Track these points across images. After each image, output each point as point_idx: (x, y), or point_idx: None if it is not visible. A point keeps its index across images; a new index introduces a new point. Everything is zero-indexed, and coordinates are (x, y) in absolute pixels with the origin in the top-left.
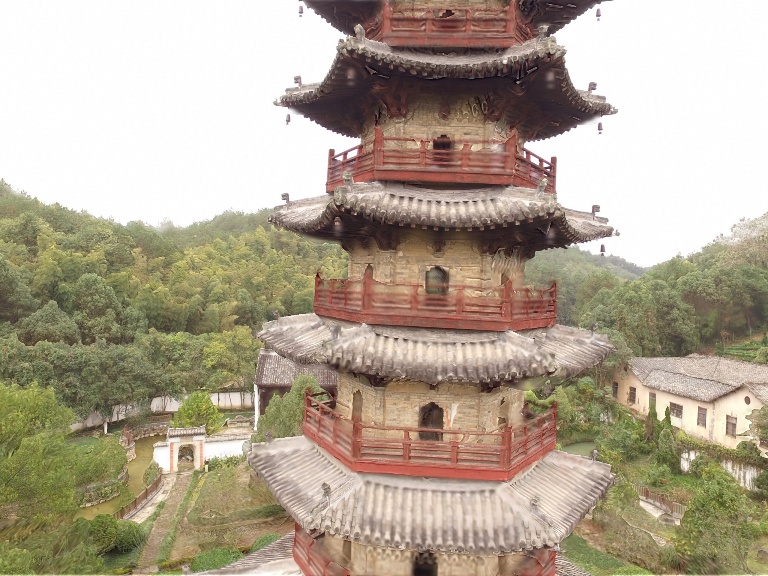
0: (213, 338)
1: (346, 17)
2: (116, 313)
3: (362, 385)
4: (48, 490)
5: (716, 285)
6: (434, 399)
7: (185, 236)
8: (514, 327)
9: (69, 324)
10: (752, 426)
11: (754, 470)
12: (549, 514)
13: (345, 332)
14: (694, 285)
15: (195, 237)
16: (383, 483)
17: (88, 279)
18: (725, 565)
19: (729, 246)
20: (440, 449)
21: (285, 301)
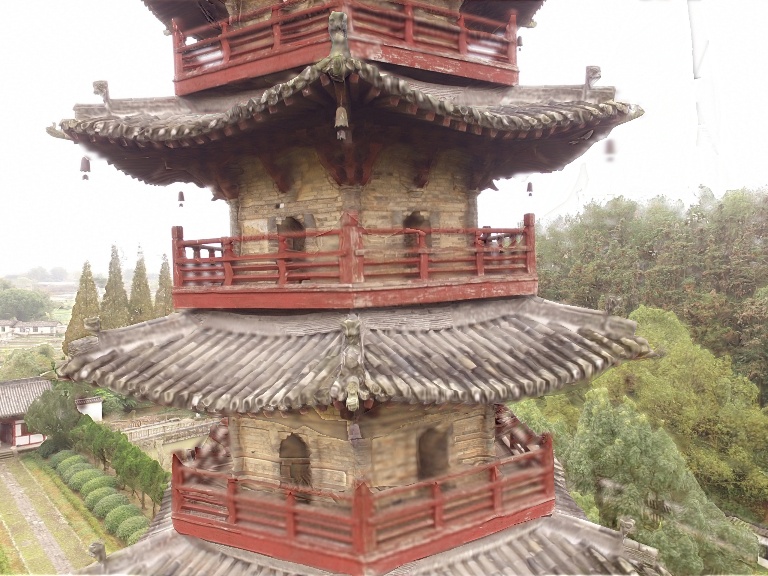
0: None
1: (489, 24)
2: None
3: None
4: None
5: None
6: None
7: None
8: None
9: None
10: None
11: None
12: None
13: None
14: None
15: None
16: None
17: None
18: None
19: None
20: None
21: None
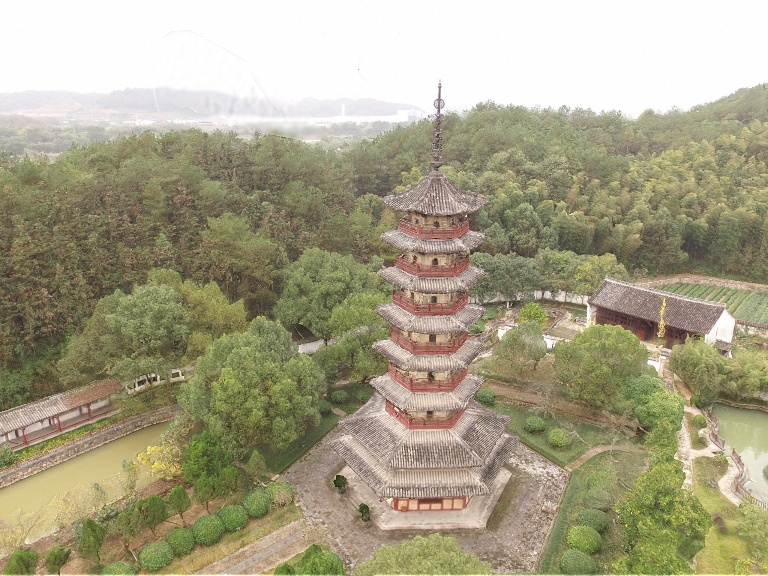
0: (588, 259)
1: None
2: (538, 230)
3: None
4: None
5: None
6: None
7: (688, 125)
8: (416, 353)
9: (502, 239)
10: None
11: None
12: (421, 405)
13: (382, 341)
14: None
15: (694, 127)
16: None
17: (522, 208)
18: None
19: None
20: None
21: (713, 218)
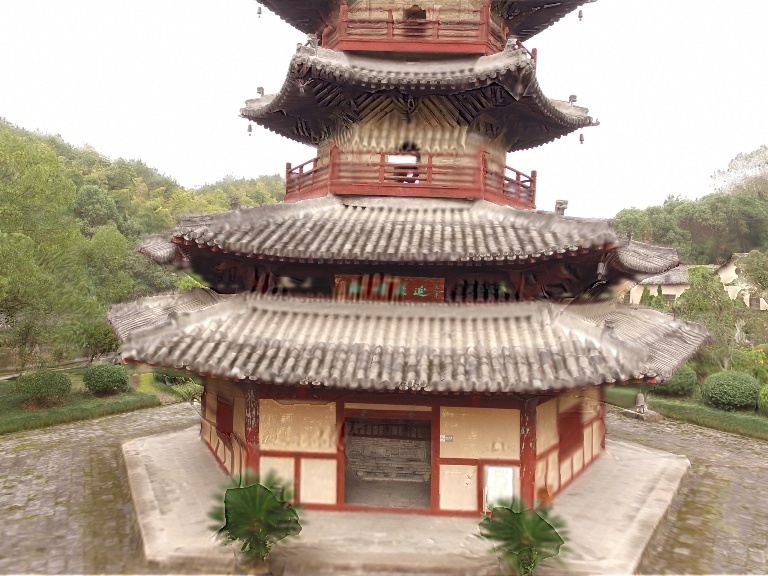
0: None
1: None
2: (117, 225)
3: (350, 8)
4: (51, 220)
5: (712, 212)
6: (417, 1)
7: None
8: None
9: None
10: (740, 274)
11: (742, 321)
12: None
13: None
14: (690, 212)
15: None
16: (368, 68)
17: (89, 189)
18: (708, 348)
19: (726, 181)
20: (422, 27)
21: None
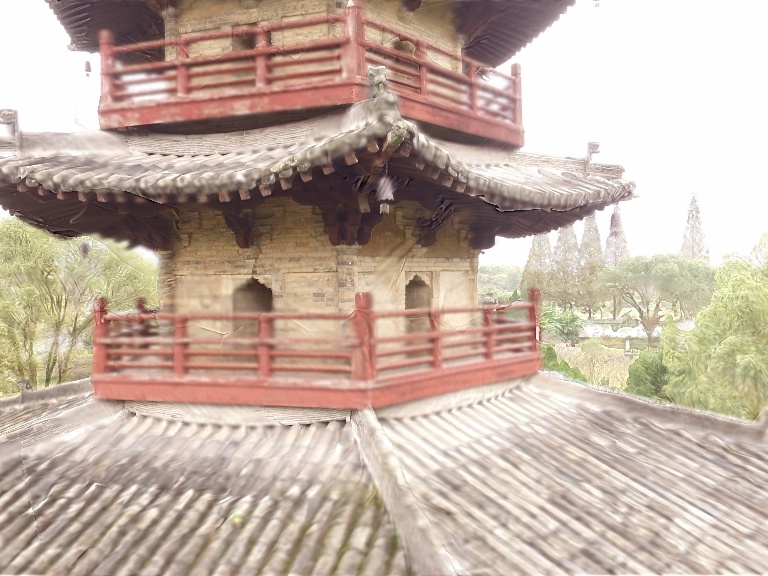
0: None
1: None
2: None
3: None
4: None
5: None
6: None
7: None
8: None
9: None
10: None
11: None
12: None
13: None
14: None
15: None
16: None
17: None
18: None
19: None
20: None
21: None
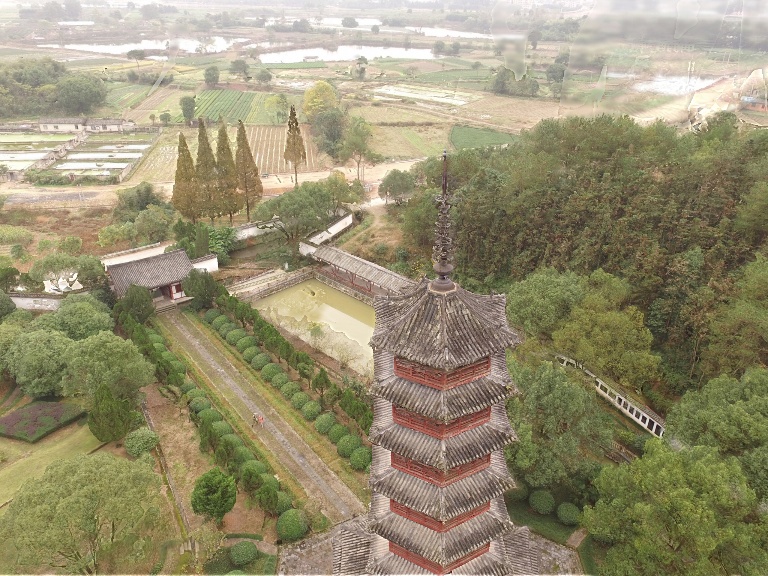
0: None
1: None
2: None
3: None
4: None
5: None
6: None
7: None
8: None
9: None
10: None
11: None
12: None
13: None
14: None
15: None
16: None
17: None
18: None
19: None
20: None
21: None
